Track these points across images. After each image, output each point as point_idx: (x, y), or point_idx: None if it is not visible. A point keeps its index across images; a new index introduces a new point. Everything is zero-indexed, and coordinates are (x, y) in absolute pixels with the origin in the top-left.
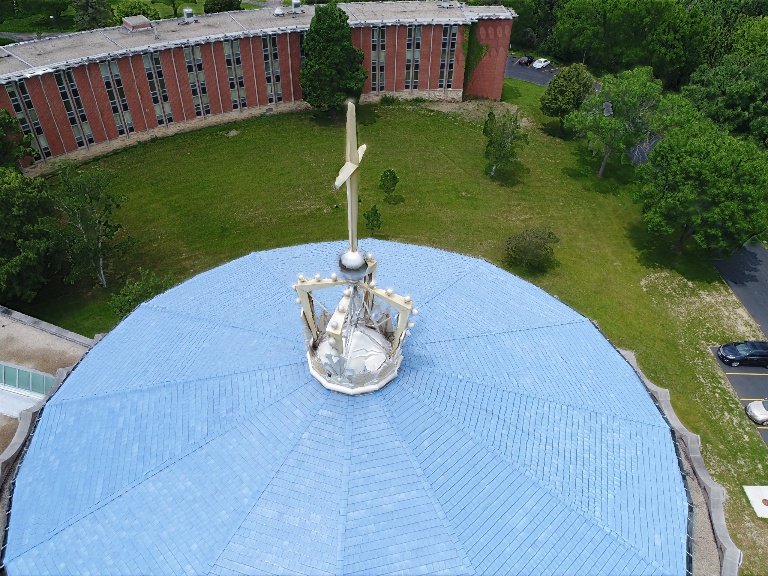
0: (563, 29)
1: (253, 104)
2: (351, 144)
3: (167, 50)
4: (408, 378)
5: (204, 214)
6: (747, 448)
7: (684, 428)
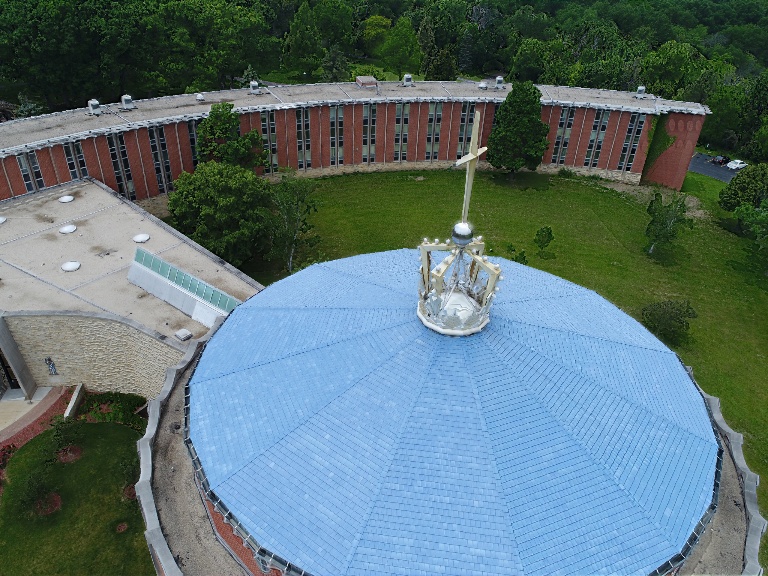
0: (766, 134)
1: (443, 158)
2: (473, 140)
3: (384, 104)
4: (489, 336)
5: (379, 235)
6: None
7: (747, 468)
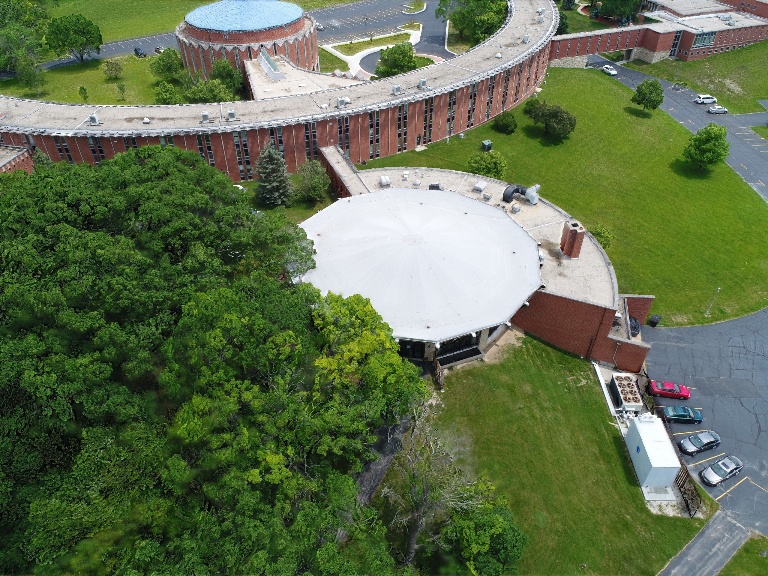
0: None
1: None
2: None
3: None
4: None
5: None
6: None
7: None
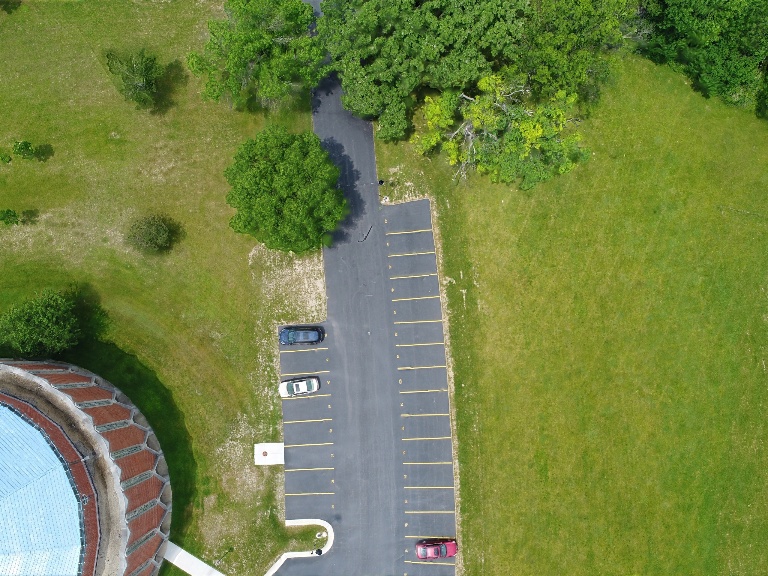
0: None
1: None
2: None
3: None
4: None
5: None
6: (269, 416)
7: (124, 511)
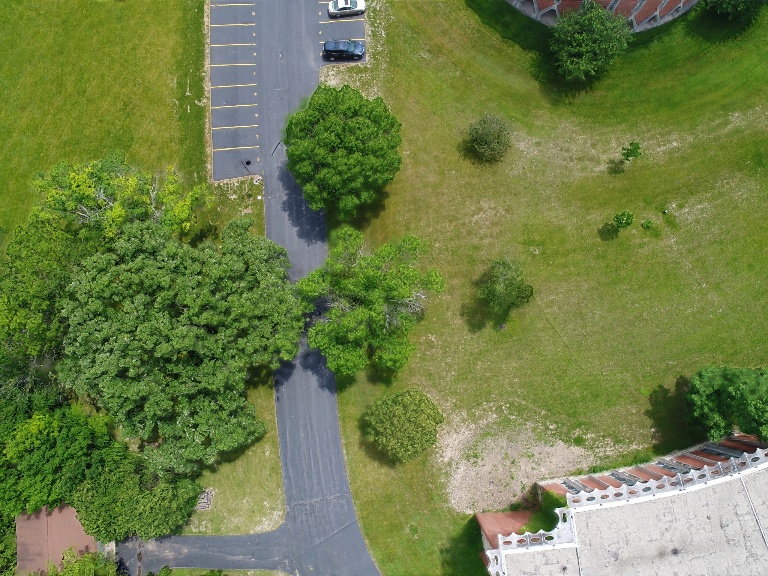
0: None
1: None
2: None
3: None
4: None
5: None
6: None
7: None
